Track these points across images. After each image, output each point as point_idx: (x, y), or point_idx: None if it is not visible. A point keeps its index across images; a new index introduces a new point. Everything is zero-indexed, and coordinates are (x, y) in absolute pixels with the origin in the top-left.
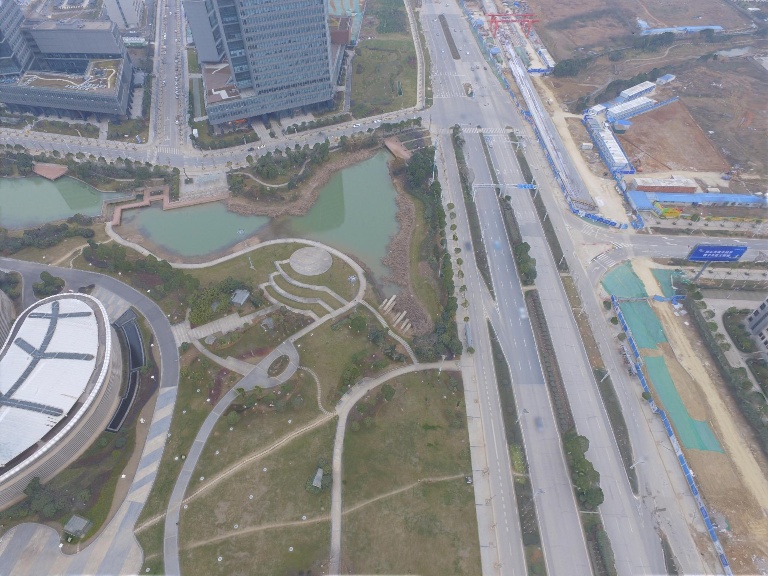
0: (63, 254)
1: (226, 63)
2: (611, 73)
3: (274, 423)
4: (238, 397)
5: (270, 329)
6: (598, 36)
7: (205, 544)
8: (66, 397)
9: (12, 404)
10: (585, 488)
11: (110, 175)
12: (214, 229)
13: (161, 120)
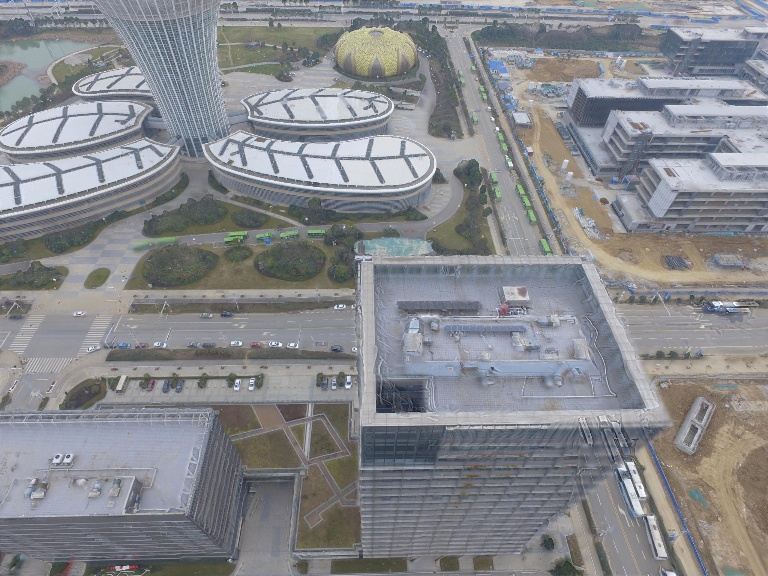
0: None
1: None
2: None
3: None
4: None
5: None
6: None
7: None
8: None
9: None
10: (232, 6)
11: None
12: (13, 94)
13: None
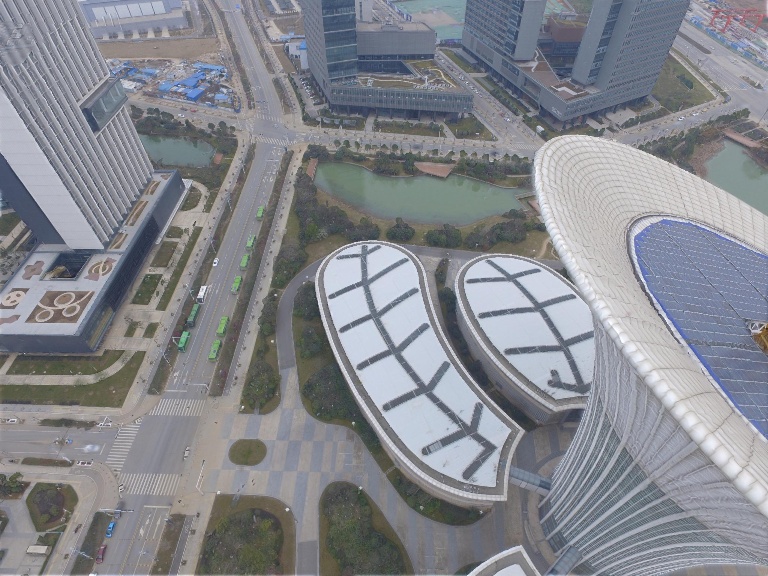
0: (539, 247)
1: (534, 61)
2: None
3: None
4: None
5: None
6: None
7: None
8: None
9: None
10: None
11: (501, 171)
12: None
13: (488, 118)
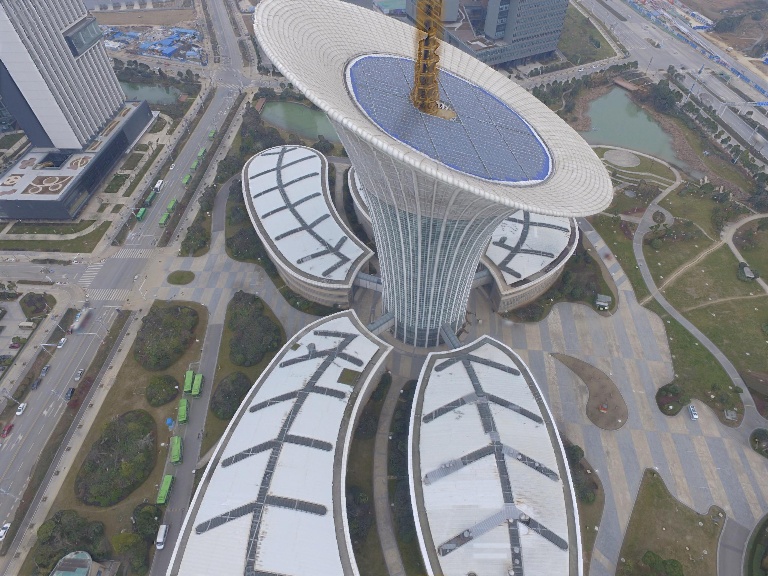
0: None
1: (459, 23)
2: (760, 29)
3: (686, 247)
4: (645, 235)
5: (644, 193)
6: (733, 1)
7: (696, 308)
8: (564, 222)
9: (535, 225)
10: None
11: None
12: None
13: None
